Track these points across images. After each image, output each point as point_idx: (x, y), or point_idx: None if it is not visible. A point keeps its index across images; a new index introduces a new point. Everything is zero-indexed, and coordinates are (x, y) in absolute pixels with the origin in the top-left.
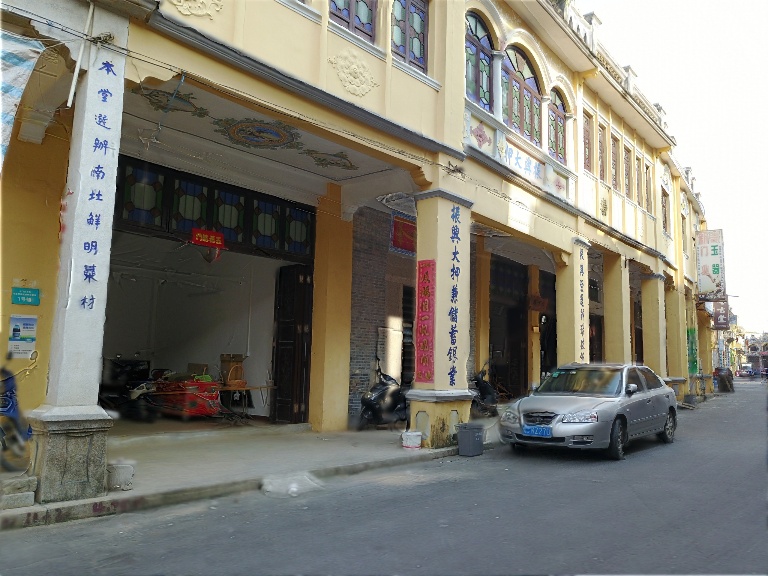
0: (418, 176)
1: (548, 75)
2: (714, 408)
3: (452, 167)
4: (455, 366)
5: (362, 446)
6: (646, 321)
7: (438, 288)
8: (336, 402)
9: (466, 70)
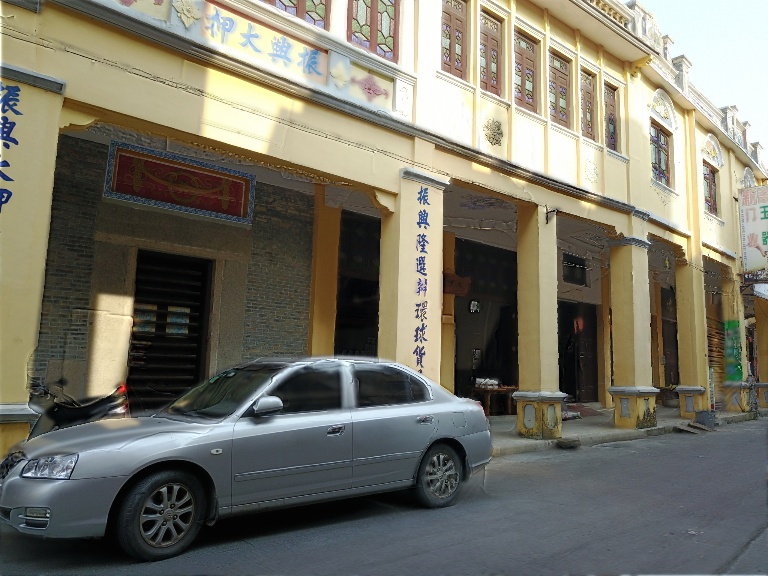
0: None
1: None
2: (740, 431)
3: None
4: None
5: None
6: (616, 305)
7: None
8: None
9: None
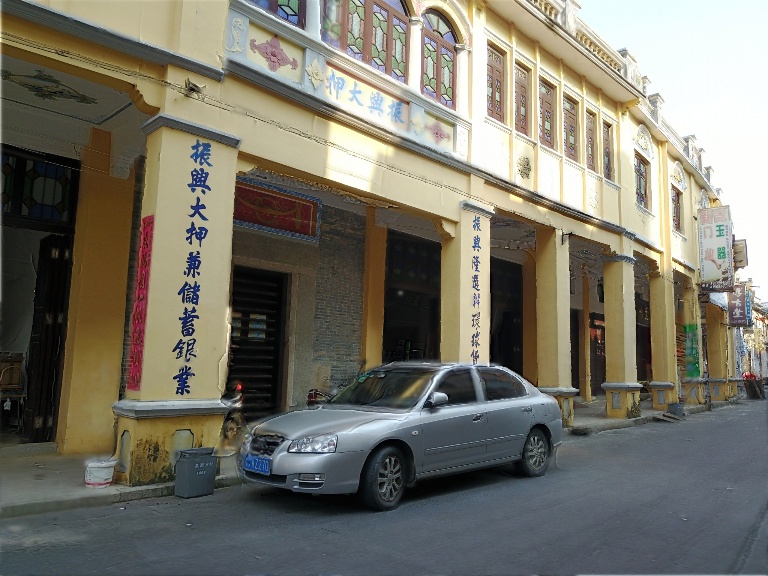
0: (138, 99)
1: None
2: (705, 420)
3: (195, 87)
4: (190, 366)
5: (45, 480)
6: (608, 313)
7: (155, 255)
8: (93, 414)
9: None
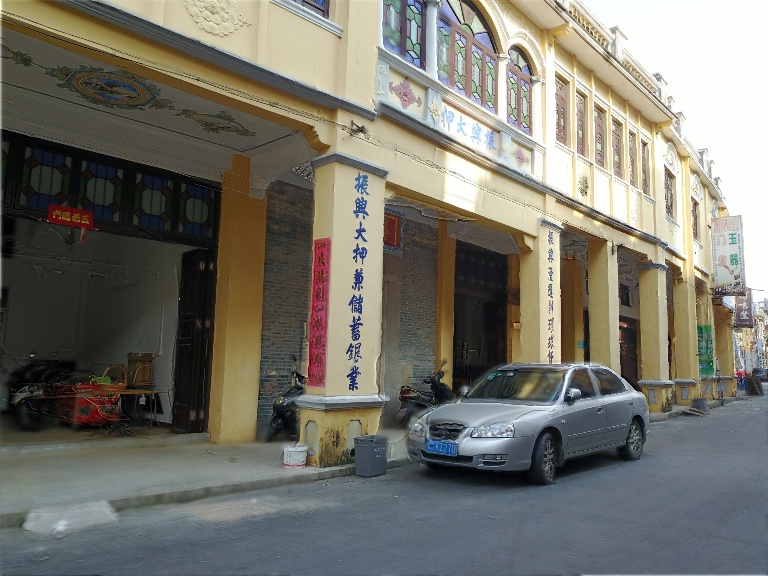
0: (312, 138)
1: (505, 30)
2: (727, 414)
3: (357, 127)
4: (358, 366)
5: (240, 463)
6: (644, 316)
7: (333, 272)
8: (240, 408)
9: (386, 16)
